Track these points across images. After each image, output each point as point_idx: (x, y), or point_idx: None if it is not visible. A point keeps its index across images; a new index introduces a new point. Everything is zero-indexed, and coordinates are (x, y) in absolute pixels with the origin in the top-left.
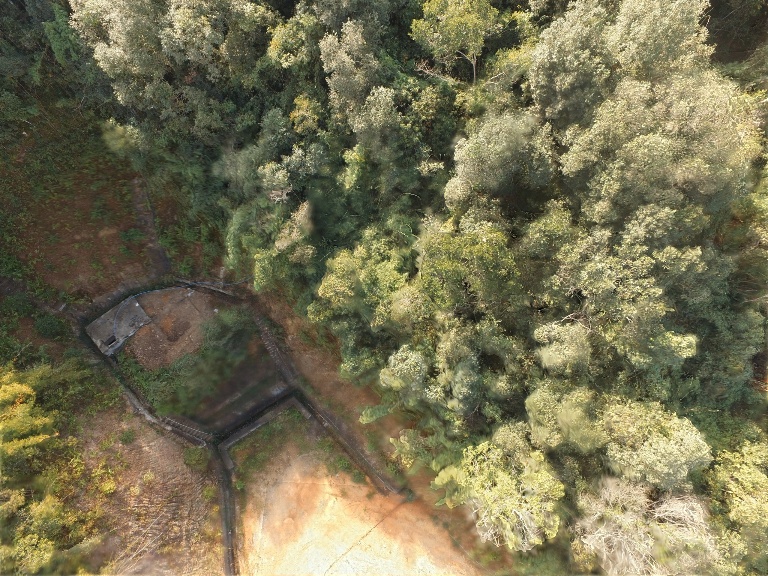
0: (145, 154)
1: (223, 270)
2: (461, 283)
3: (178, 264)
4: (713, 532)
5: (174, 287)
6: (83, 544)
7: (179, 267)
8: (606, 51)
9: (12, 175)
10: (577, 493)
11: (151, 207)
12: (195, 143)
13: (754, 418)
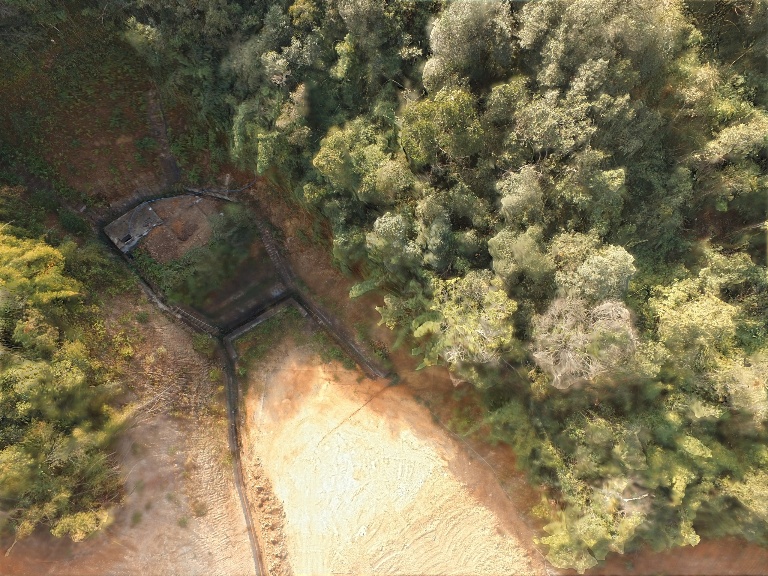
0: (161, 57)
1: (228, 177)
2: (434, 139)
3: (187, 173)
4: (641, 340)
5: (184, 195)
6: (107, 385)
7: (188, 176)
8: None
9: (41, 79)
10: (532, 325)
11: (164, 117)
12: (205, 46)
13: (686, 266)
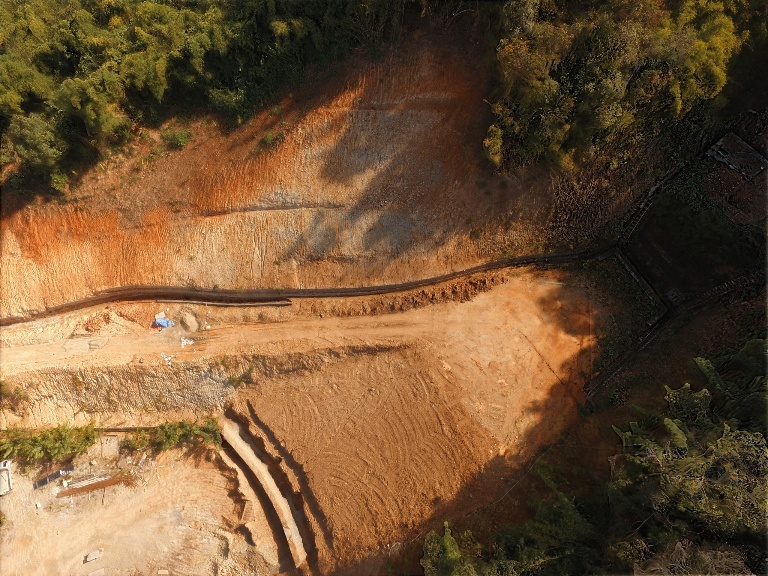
0: None
1: None
2: None
3: None
4: None
5: None
6: (592, 149)
7: None
8: None
9: None
10: None
11: None
12: None
13: None
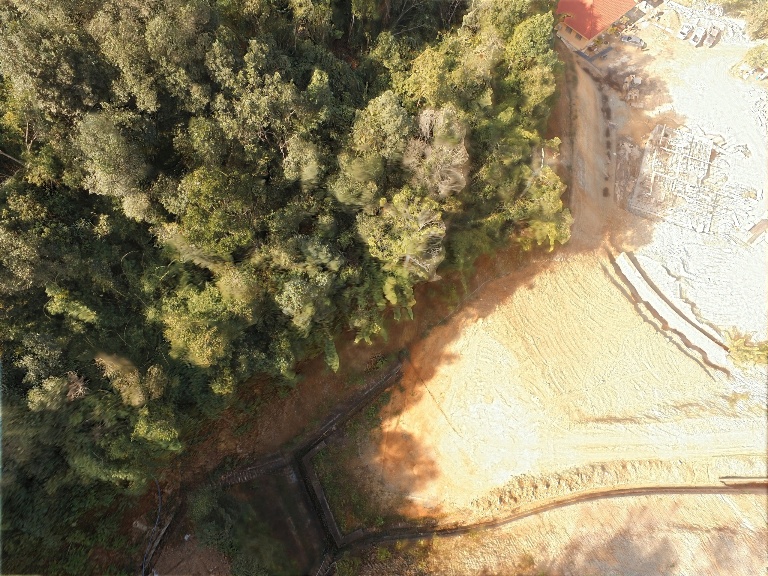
0: None
1: (138, 524)
2: (232, 217)
3: None
4: None
5: None
6: None
7: None
8: (51, 29)
9: None
10: None
11: None
12: None
13: None
